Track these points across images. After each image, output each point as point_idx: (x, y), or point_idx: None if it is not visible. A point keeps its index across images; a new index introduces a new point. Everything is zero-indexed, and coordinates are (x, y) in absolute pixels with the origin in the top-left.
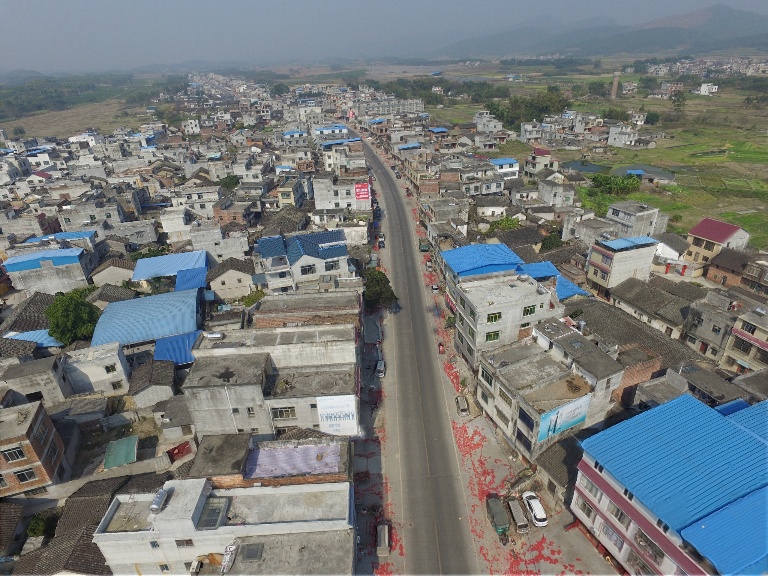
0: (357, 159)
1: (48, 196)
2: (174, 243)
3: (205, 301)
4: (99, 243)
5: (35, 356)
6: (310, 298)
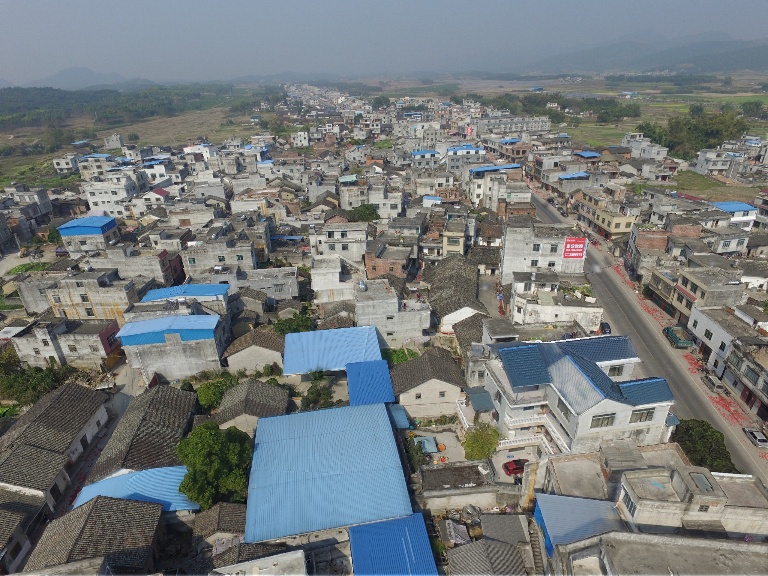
0: (521, 191)
1: (167, 221)
2: (323, 304)
3: (397, 429)
4: (231, 298)
5: (157, 528)
6: (710, 549)
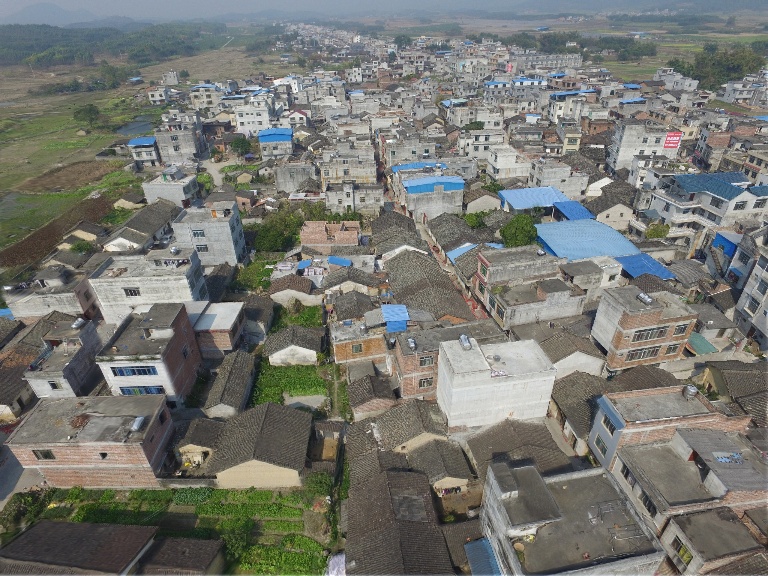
0: (600, 110)
1: (333, 132)
2: (501, 179)
3: None
4: None
5: None
6: None
